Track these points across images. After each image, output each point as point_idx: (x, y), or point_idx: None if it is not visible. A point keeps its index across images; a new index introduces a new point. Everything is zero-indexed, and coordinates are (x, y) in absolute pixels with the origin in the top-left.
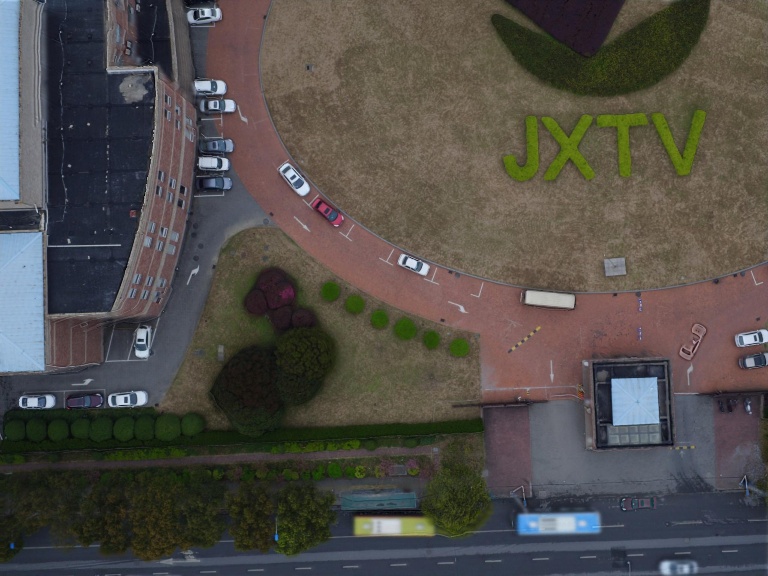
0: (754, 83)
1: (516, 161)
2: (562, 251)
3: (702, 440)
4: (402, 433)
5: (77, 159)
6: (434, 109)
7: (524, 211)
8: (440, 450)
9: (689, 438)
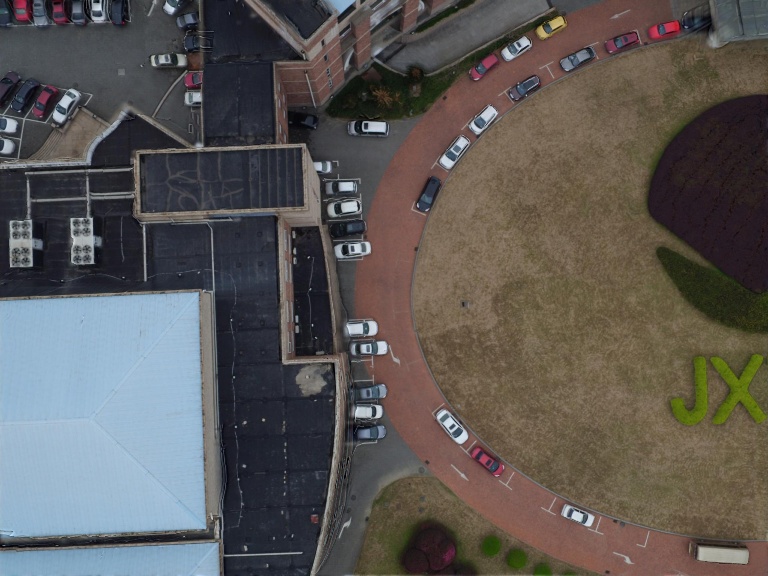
0: None
1: (684, 404)
2: (731, 497)
3: None
4: None
5: (252, 458)
6: (597, 349)
7: (692, 456)
8: None
9: None
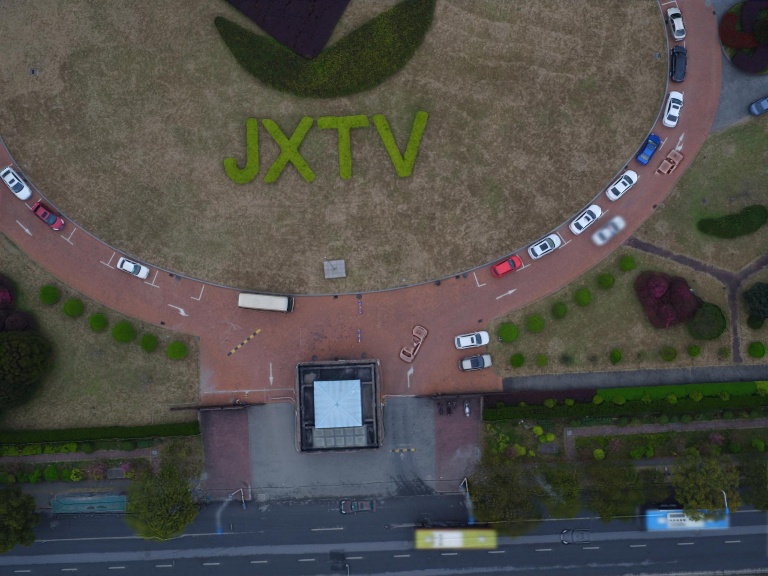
0: (479, 84)
1: (236, 164)
2: (282, 253)
3: (422, 442)
4: (117, 436)
5: None
6: (156, 112)
7: (245, 214)
8: (159, 453)
9: (409, 440)
